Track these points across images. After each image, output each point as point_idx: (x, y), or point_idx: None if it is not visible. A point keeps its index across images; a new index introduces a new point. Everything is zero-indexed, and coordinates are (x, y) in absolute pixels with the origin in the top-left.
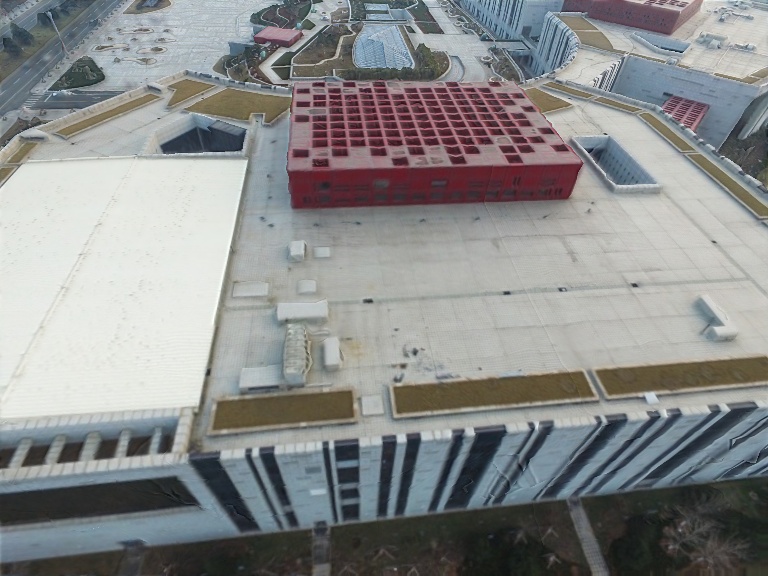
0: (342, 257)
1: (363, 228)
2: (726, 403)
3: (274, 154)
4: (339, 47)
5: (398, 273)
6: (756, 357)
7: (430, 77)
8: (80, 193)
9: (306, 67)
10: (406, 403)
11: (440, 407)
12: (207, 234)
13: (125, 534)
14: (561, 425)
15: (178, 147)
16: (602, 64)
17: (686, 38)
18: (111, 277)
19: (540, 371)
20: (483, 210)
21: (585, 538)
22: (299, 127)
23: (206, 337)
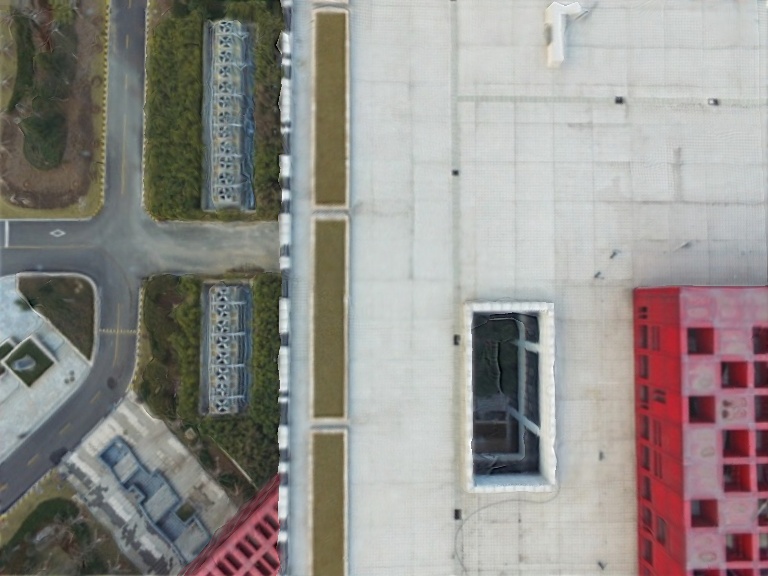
0: None
1: None
2: None
3: None
4: None
5: None
6: None
7: None
8: None
9: None
10: None
11: None
12: None
13: None
14: None
15: None
16: None
17: None
18: None
19: None
20: None
21: None
22: None
23: None
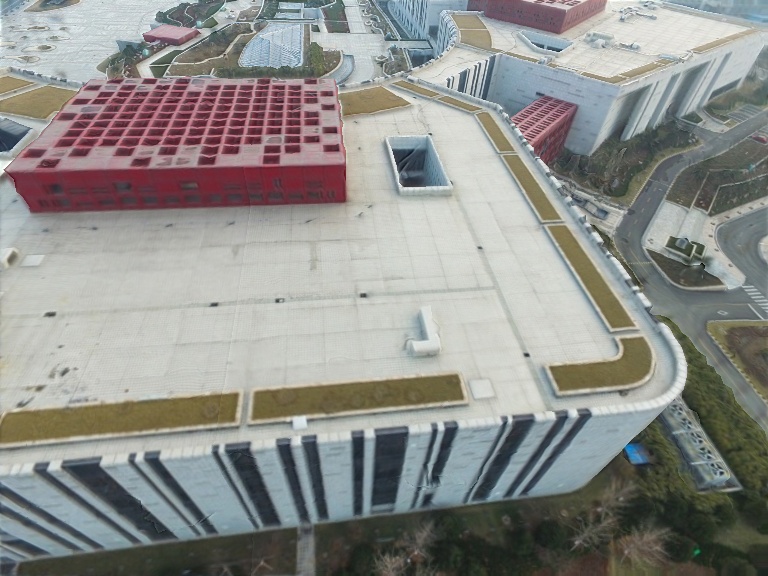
0: (52, 266)
1: (97, 234)
2: (375, 428)
3: None
4: (231, 46)
5: (104, 283)
6: (445, 375)
7: (310, 76)
8: None
9: (185, 66)
10: (8, 432)
11: (45, 436)
12: None
13: None
14: (168, 456)
15: None
16: (470, 63)
17: (575, 37)
18: None
19: (193, 393)
20: (244, 214)
21: (303, 570)
22: (56, 125)
23: None
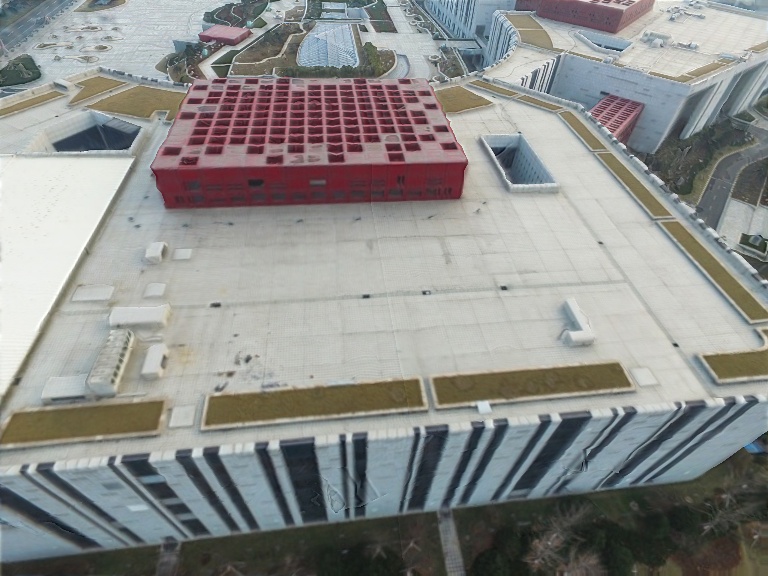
0: (202, 259)
1: (234, 229)
2: (559, 412)
3: None
4: (285, 45)
5: (257, 276)
6: (607, 363)
7: (371, 76)
8: None
9: (246, 65)
10: (217, 414)
11: (253, 418)
12: (64, 235)
13: None
14: (375, 437)
15: (76, 145)
16: (537, 62)
17: (631, 37)
18: None
19: (375, 379)
20: (367, 210)
21: (449, 552)
22: (181, 124)
23: (24, 344)
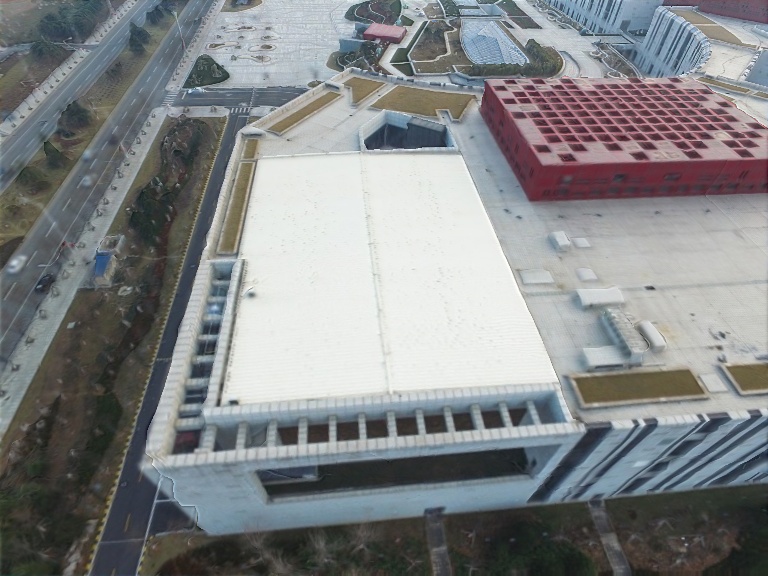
0: (602, 247)
1: (606, 220)
2: None
3: (480, 149)
4: (447, 43)
5: (663, 262)
6: None
7: (551, 72)
8: (331, 187)
9: (426, 63)
10: (747, 381)
11: None
12: (469, 225)
13: (431, 502)
14: None
15: (371, 143)
16: (739, 58)
17: None
18: (410, 265)
19: None
20: (709, 203)
21: None
22: (522, 123)
23: (529, 320)
